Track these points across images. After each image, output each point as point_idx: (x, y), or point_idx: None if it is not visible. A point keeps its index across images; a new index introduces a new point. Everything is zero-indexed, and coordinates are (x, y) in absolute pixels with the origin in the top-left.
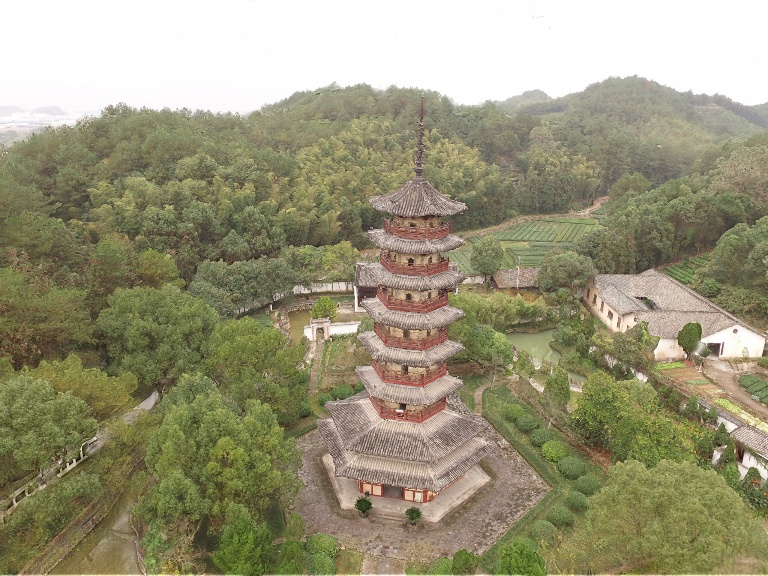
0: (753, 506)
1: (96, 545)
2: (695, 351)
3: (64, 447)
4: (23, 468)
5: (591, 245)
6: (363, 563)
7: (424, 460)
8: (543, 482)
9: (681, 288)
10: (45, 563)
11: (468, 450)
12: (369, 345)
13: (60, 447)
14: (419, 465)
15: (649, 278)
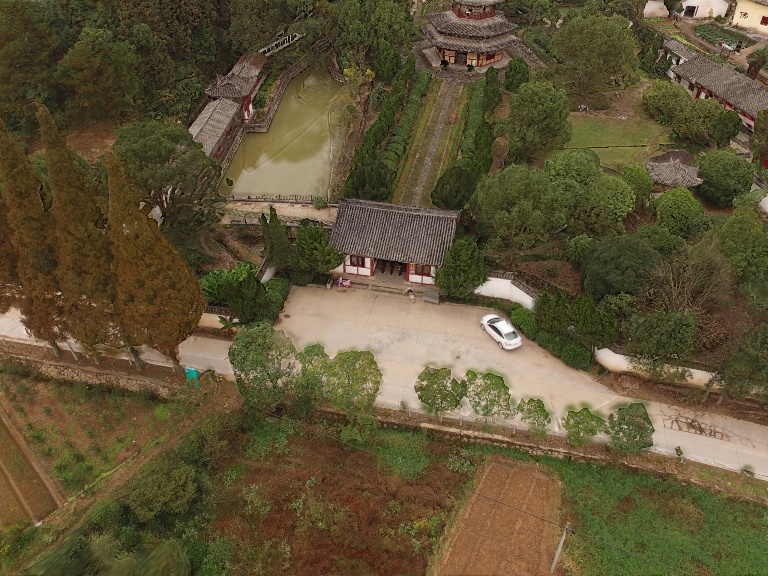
0: (657, 73)
1: (308, 78)
2: (674, 9)
3: (306, 3)
4: (291, 9)
5: None
6: (443, 82)
7: (479, 36)
8: (546, 65)
9: None
10: (291, 72)
11: (505, 40)
12: None
13: (305, 3)
14: (476, 42)
15: None
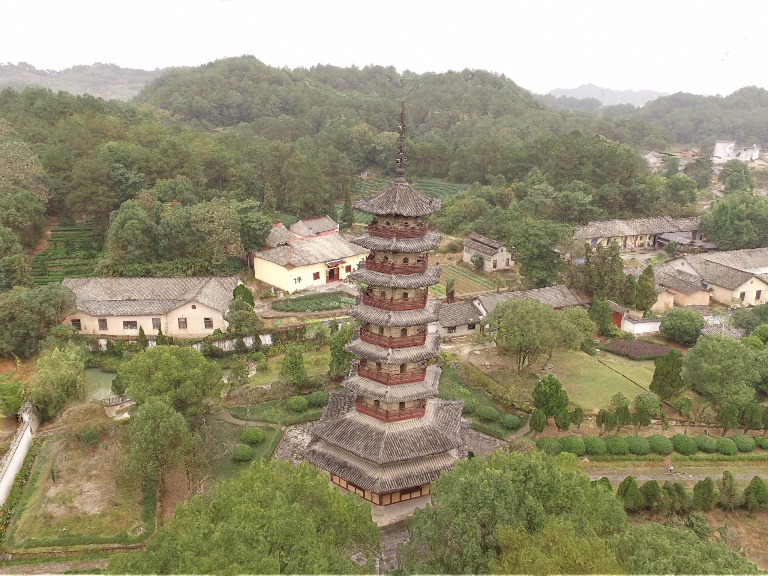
0: None
1: None
2: None
3: None
4: None
5: (3, 276)
6: None
7: None
8: None
9: (138, 278)
10: None
11: None
12: (406, 359)
13: None
14: None
15: (91, 284)
